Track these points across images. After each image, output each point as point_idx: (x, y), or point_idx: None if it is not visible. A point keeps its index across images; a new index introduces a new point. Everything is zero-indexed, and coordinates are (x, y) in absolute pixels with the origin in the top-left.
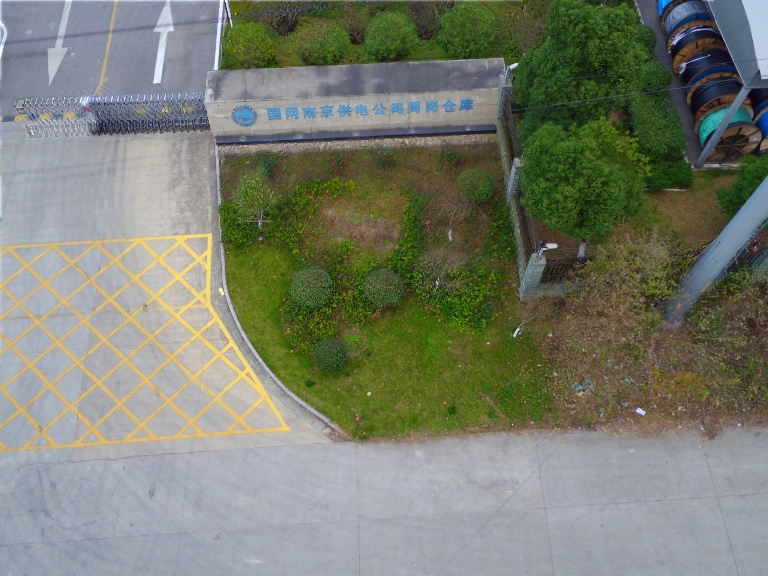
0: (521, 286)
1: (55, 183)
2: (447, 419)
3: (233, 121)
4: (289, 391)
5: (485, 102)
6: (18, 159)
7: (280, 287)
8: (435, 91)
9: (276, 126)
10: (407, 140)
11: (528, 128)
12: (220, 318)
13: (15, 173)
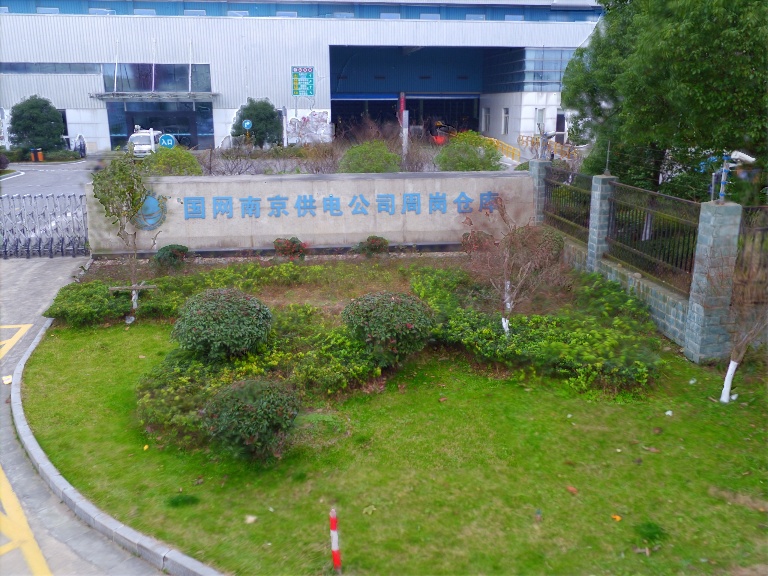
0: (689, 324)
1: None
2: (646, 552)
3: None
4: (108, 518)
5: (515, 198)
6: None
7: (150, 367)
8: (441, 178)
9: (196, 232)
10: (403, 254)
11: (602, 141)
12: None
13: None
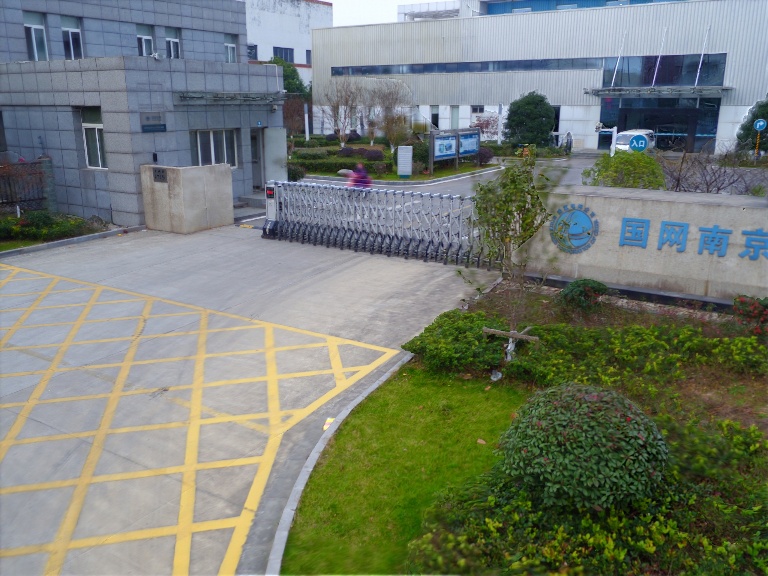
0: None
1: (238, 263)
2: None
3: (549, 237)
4: None
5: None
6: (227, 244)
7: (481, 463)
8: None
9: (630, 263)
10: None
11: None
12: (274, 461)
13: (208, 250)
